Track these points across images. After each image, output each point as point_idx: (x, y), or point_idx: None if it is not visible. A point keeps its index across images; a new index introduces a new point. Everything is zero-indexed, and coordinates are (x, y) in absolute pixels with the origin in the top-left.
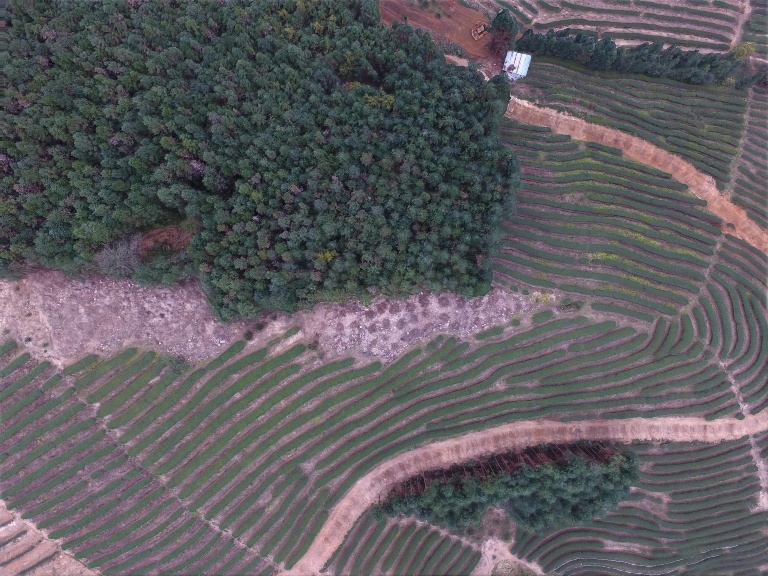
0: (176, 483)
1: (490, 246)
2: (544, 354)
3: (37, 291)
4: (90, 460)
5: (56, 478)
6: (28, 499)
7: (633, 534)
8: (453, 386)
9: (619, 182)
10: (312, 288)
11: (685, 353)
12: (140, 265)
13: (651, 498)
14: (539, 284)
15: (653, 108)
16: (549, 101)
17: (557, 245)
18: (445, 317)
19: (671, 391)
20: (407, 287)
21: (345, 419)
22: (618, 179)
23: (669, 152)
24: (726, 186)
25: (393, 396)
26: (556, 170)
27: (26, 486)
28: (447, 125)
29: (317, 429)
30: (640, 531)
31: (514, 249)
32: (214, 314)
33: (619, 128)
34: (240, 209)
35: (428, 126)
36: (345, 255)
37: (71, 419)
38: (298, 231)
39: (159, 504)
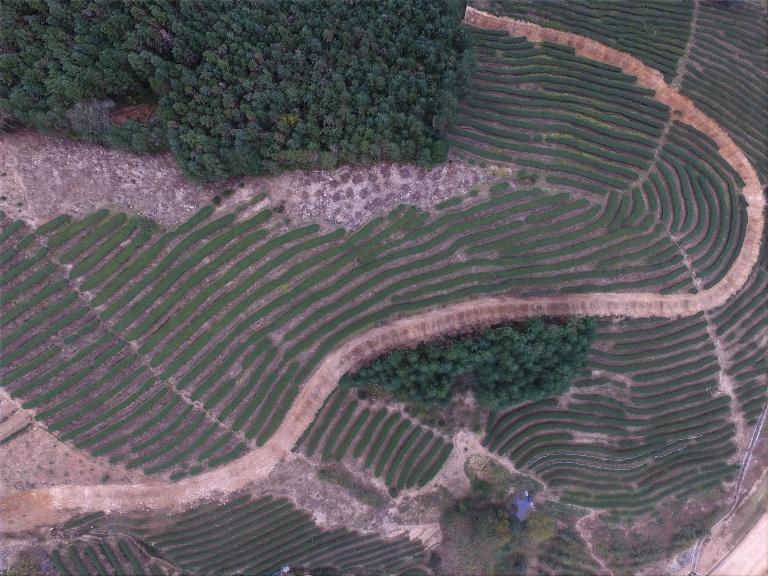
0: (147, 348)
1: (444, 106)
2: (502, 226)
3: (12, 153)
4: (63, 323)
5: (30, 342)
6: (2, 365)
7: (601, 424)
8: (416, 256)
9: (572, 74)
10: (276, 147)
11: (637, 226)
12: (112, 134)
13: (615, 382)
14: (495, 157)
15: (605, 17)
16: (507, 13)
17: (512, 125)
18: (406, 188)
19: (626, 265)
20: (366, 146)
21: (312, 288)
22: (571, 71)
23: (619, 51)
24: (674, 81)
25: (358, 266)
26: (512, 65)
27: (0, 352)
28: (405, 10)
29: (285, 296)
30: (607, 420)
31: (472, 128)
32: (184, 181)
33: (572, 32)
34: (207, 74)
35: (387, 12)
36: (307, 117)
37: (44, 281)
38: (262, 92)
39: (131, 373)
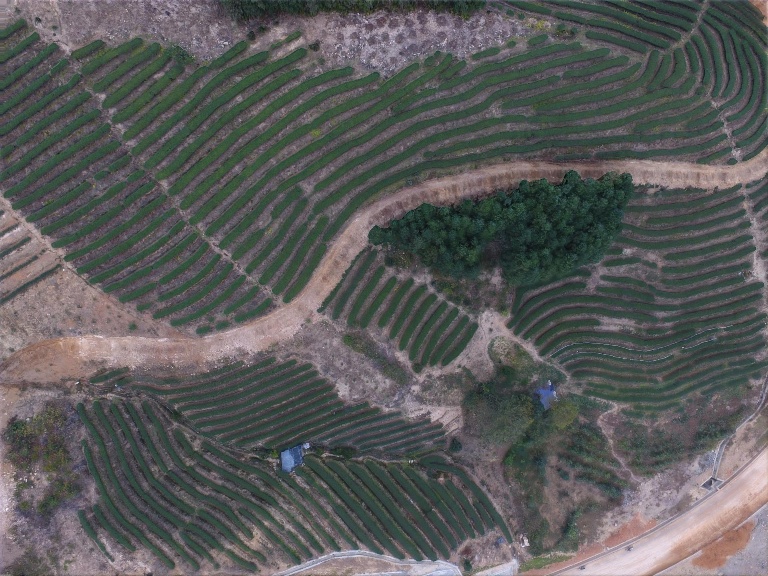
0: (178, 188)
1: None
2: None
3: None
4: (95, 156)
5: (61, 176)
6: (33, 200)
7: (628, 310)
8: (450, 109)
9: None
10: None
11: (678, 88)
12: None
13: (646, 262)
14: (535, 9)
15: None
16: None
17: None
18: (443, 35)
19: (664, 131)
20: None
21: (344, 137)
22: None
23: None
24: None
25: (391, 115)
26: None
27: (32, 185)
28: None
29: (317, 142)
30: (635, 304)
31: None
32: (218, 17)
33: None
34: None
35: None
36: None
37: (77, 111)
38: None
39: (161, 216)
